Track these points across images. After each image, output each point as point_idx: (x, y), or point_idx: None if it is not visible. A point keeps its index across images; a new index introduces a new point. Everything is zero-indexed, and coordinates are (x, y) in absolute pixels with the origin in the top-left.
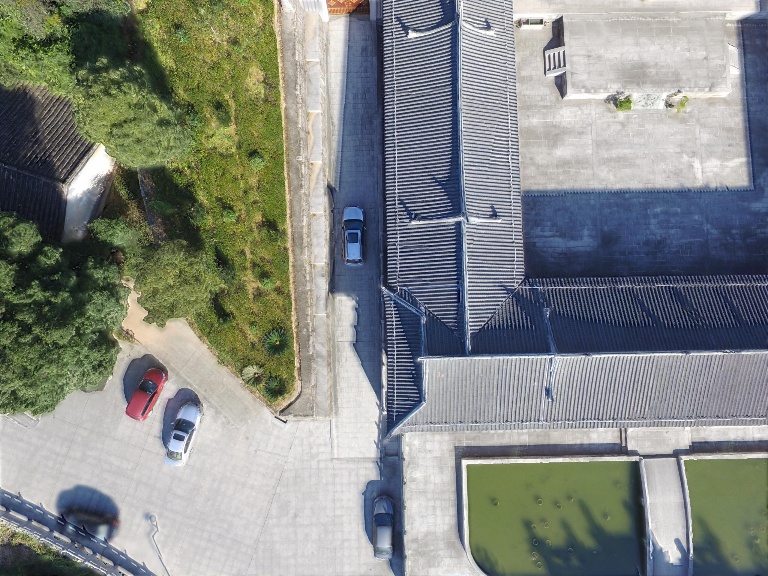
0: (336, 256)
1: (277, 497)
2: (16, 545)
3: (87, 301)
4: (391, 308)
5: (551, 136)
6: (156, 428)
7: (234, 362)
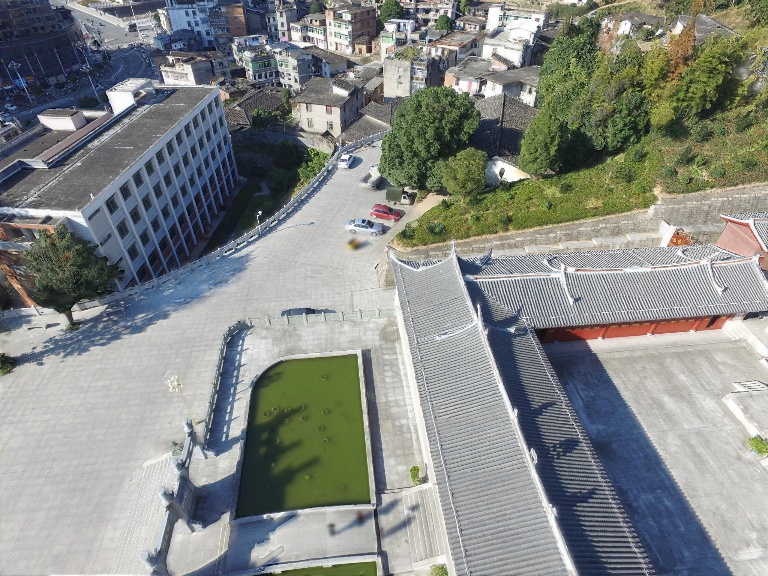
0: None
1: (325, 268)
2: None
3: (443, 159)
4: None
5: (678, 392)
6: None
7: None
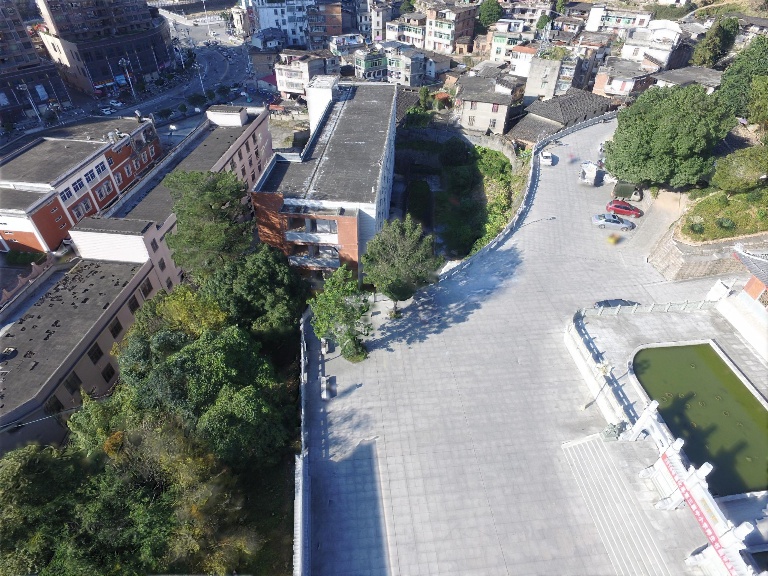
0: None
1: (598, 262)
2: (487, 198)
3: None
4: None
5: None
6: None
7: None
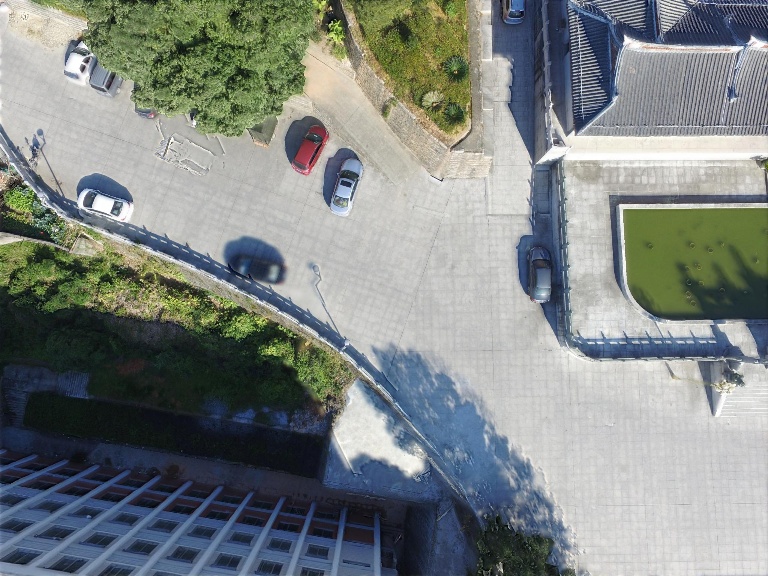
0: (493, 18)
1: (435, 250)
2: (164, 322)
3: None
4: (576, 22)
5: None
6: (317, 185)
7: (413, 91)
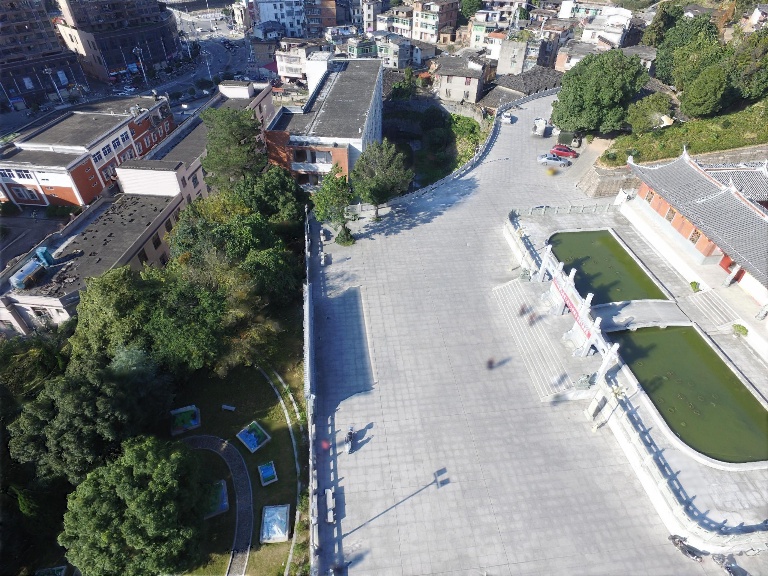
0: None
1: (538, 186)
2: (458, 152)
3: None
4: None
5: None
6: None
7: None
